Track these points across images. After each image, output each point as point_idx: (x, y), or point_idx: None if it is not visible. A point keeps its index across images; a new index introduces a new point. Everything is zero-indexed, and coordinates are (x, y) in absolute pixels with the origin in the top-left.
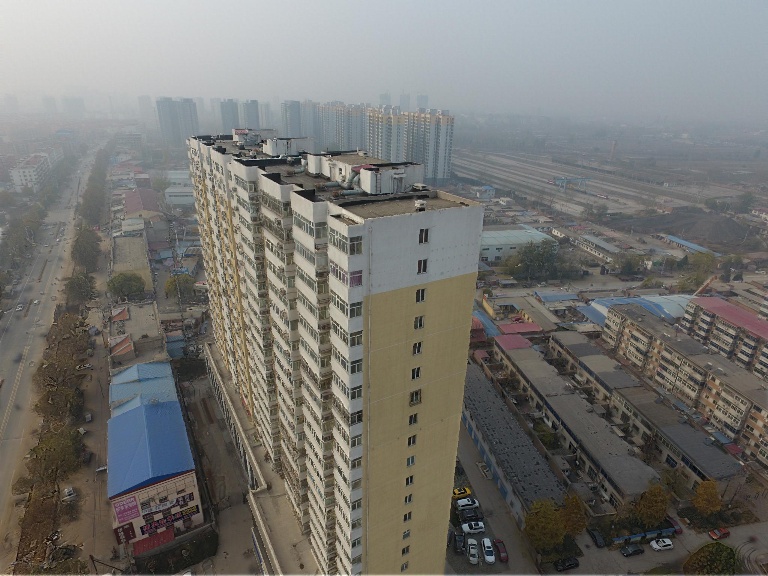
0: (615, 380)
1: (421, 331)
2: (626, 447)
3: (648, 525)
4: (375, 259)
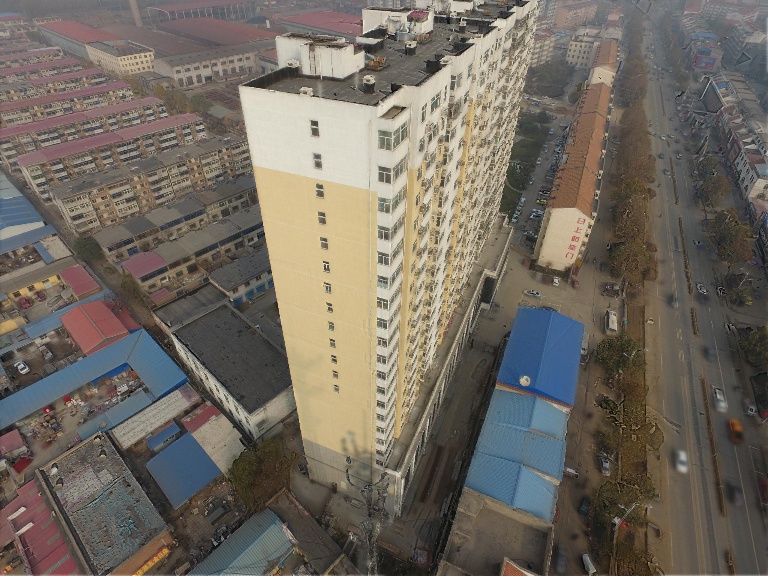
0: (191, 207)
1: None
2: None
3: None
4: None
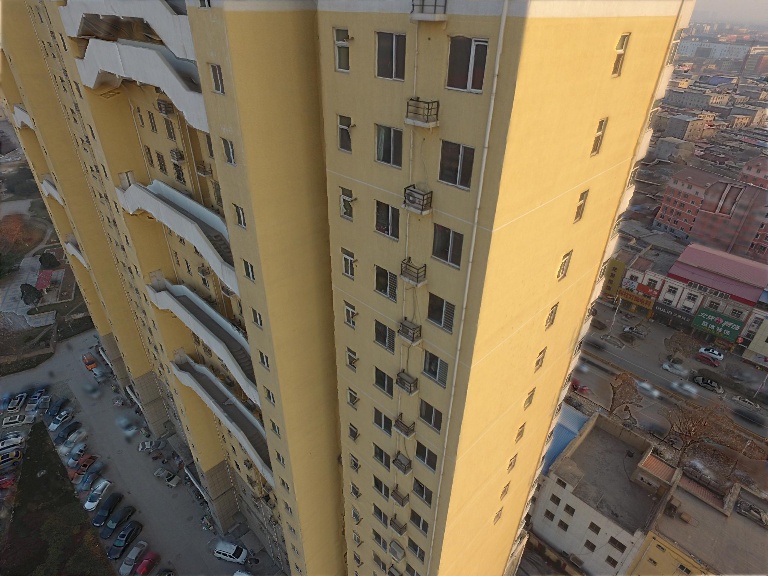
0: None
1: None
2: None
3: None
4: None
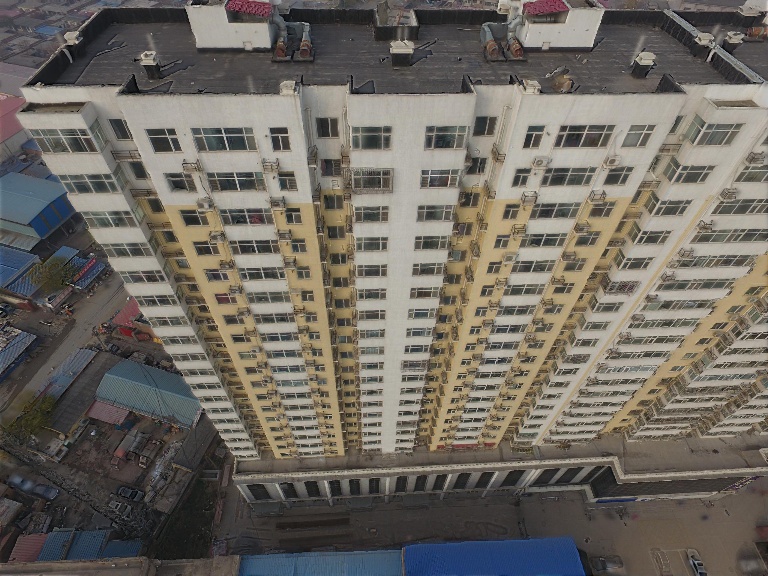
0: None
1: None
2: None
3: None
4: None
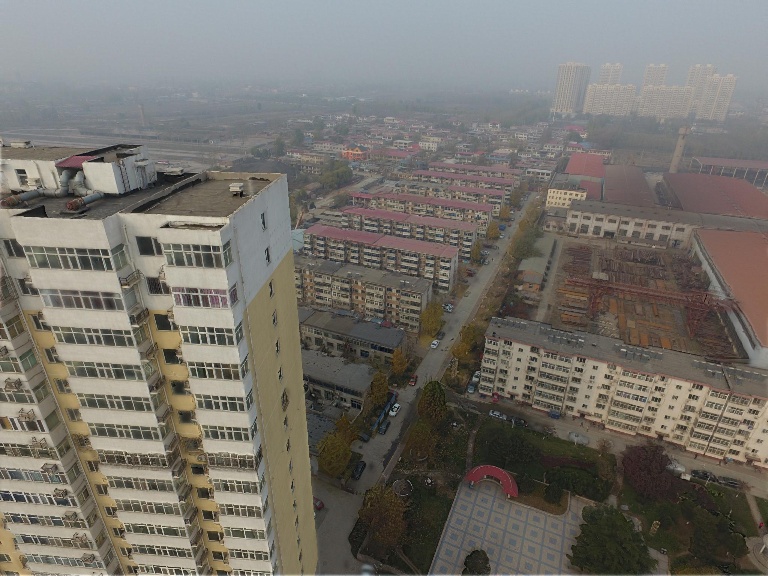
0: None
1: (277, 327)
2: (340, 361)
3: (382, 404)
4: (242, 263)
